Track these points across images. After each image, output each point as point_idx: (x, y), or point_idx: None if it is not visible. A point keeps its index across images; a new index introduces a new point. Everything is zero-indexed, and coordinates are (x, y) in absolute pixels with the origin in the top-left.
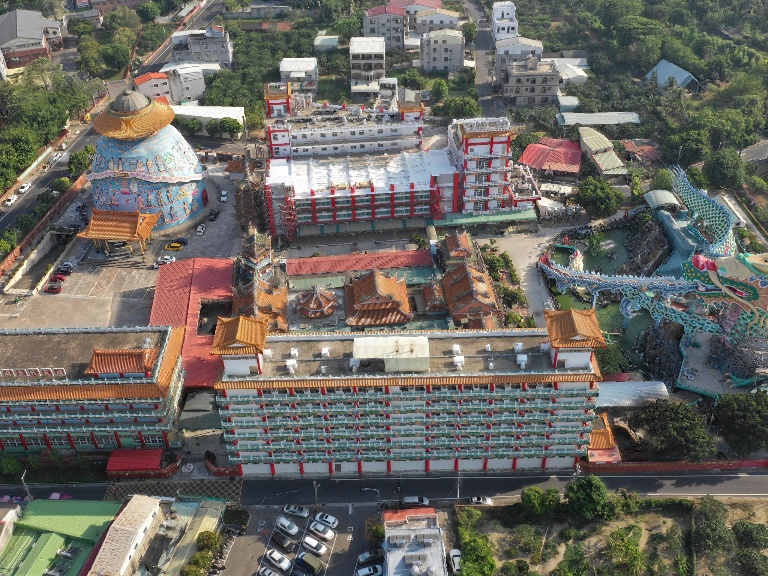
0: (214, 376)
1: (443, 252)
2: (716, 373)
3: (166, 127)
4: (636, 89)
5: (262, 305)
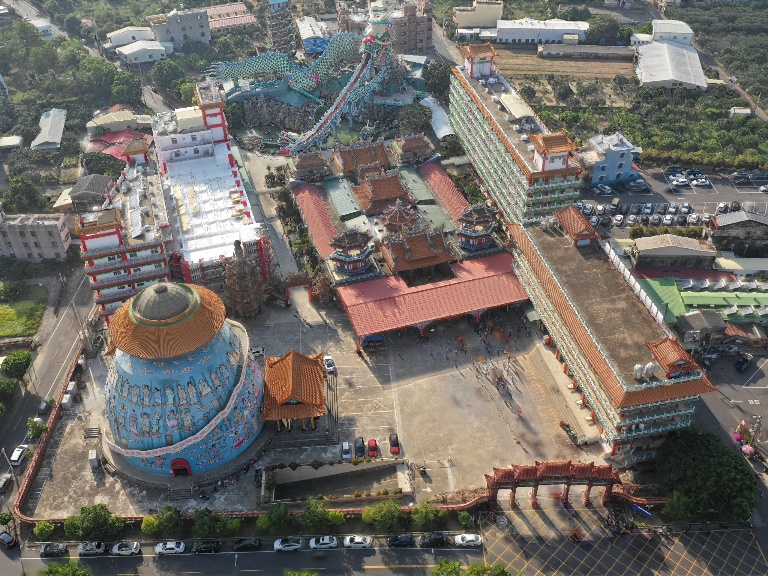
0: (501, 258)
1: (316, 168)
2: (396, 95)
3: None
4: (3, 107)
5: None
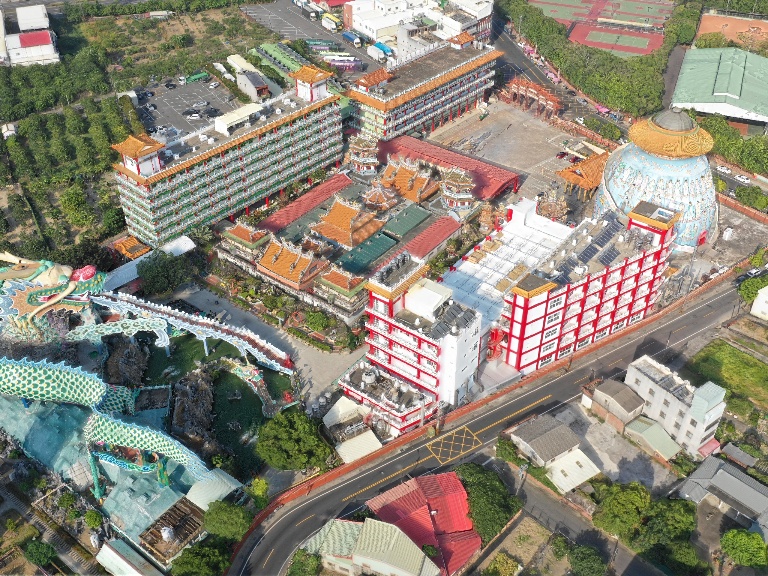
0: None
1: None
2: None
3: (660, 162)
4: None
5: (398, 169)
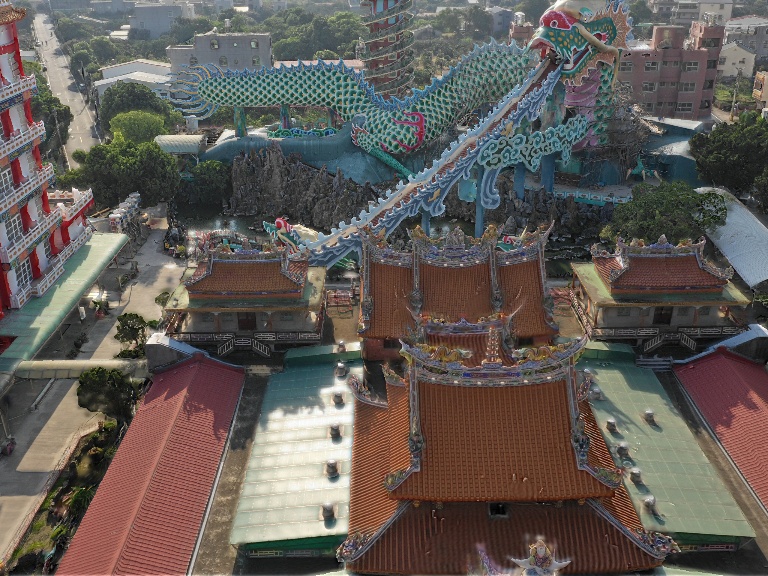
0: None
1: (259, 307)
2: (613, 187)
3: None
4: None
5: None
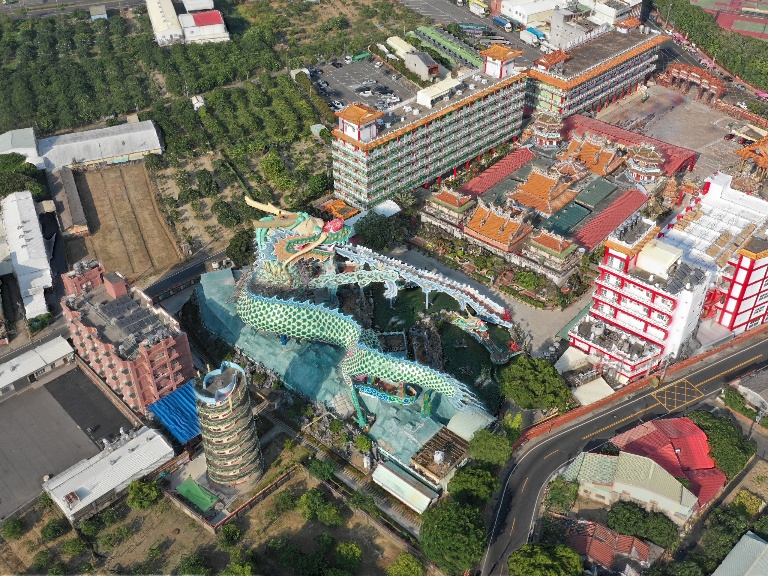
0: None
1: None
2: None
3: None
4: None
5: (583, 144)
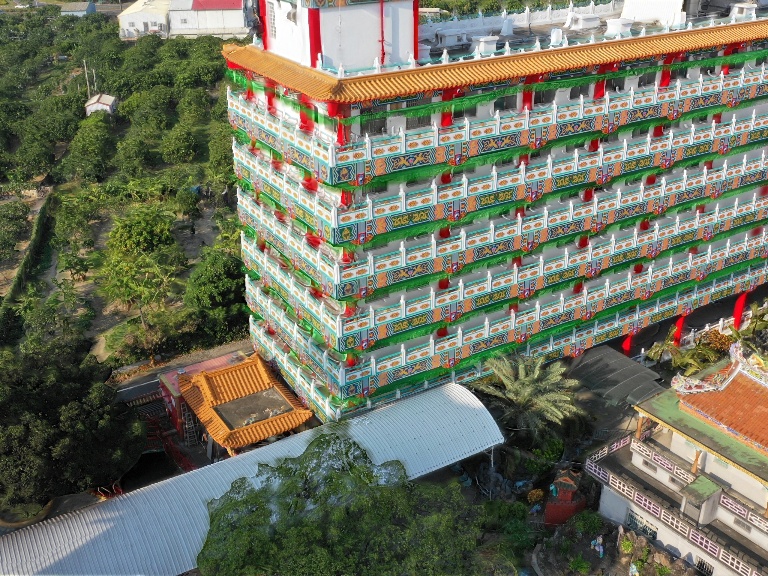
0: None
1: None
2: None
3: None
4: None
5: None
